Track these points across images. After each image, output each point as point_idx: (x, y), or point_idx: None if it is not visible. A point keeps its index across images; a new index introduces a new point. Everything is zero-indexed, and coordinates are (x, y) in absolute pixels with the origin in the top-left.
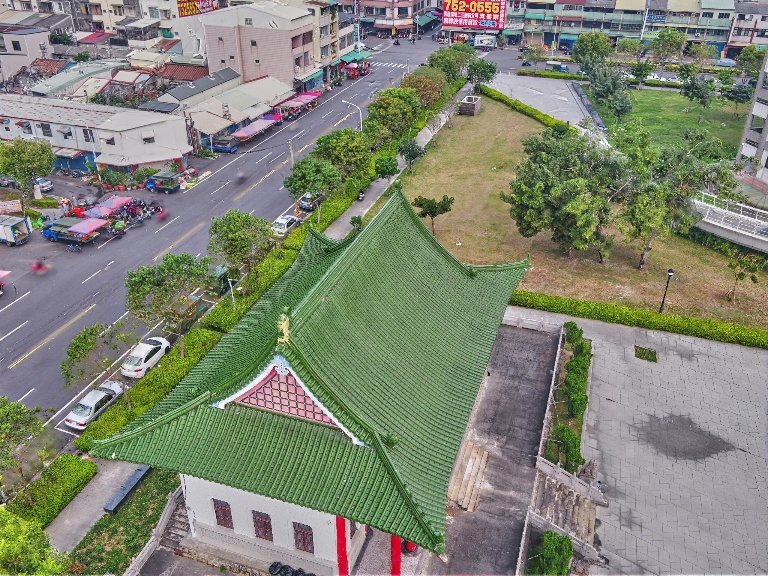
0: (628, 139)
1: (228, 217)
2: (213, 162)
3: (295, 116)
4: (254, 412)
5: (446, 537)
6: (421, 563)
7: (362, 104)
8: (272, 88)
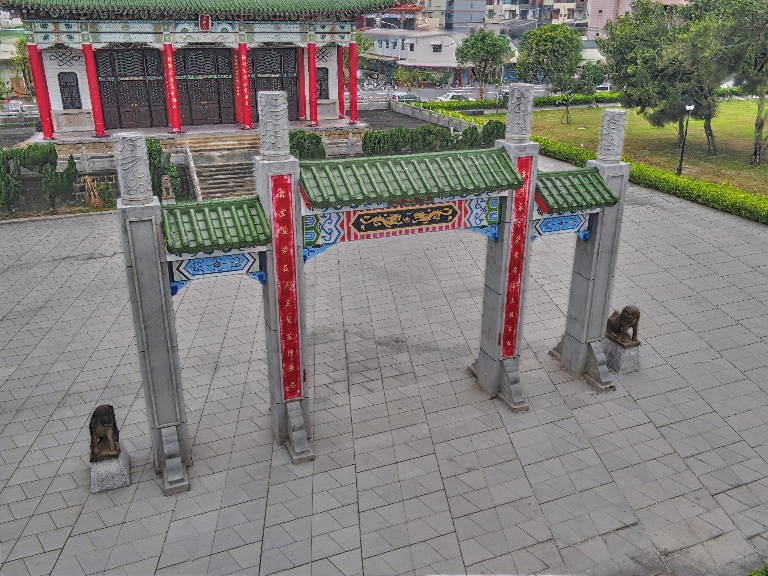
0: None
1: None
2: None
3: None
4: None
5: None
6: (87, 139)
7: None
8: None
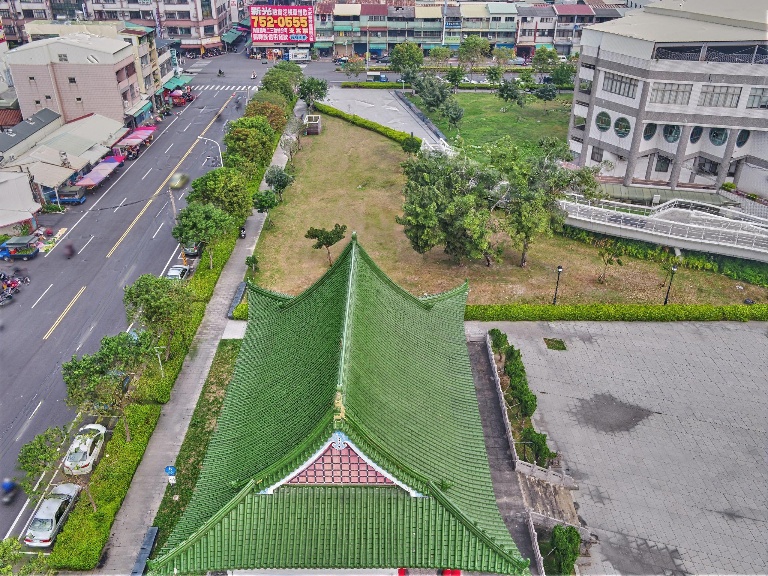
0: (502, 155)
1: (142, 283)
2: (64, 217)
3: (135, 154)
4: (304, 489)
5: None
6: None
7: (218, 138)
8: (102, 127)
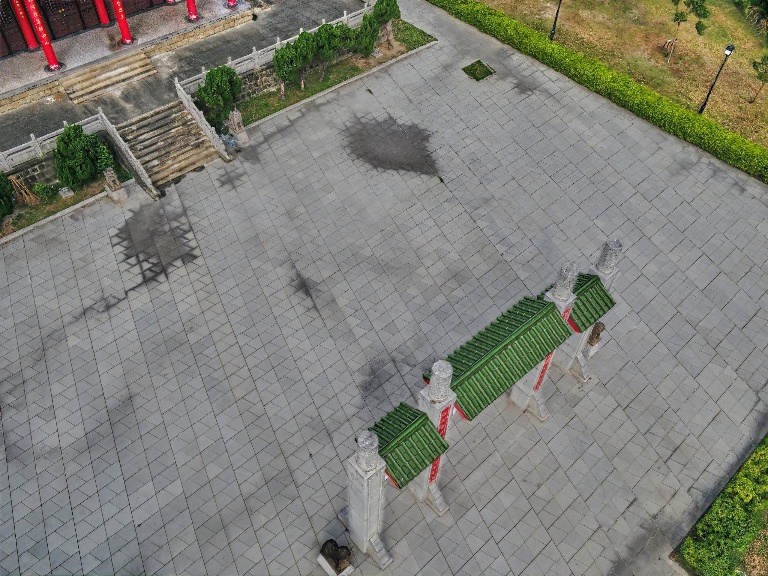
0: None
1: None
2: None
3: None
4: None
5: (28, 110)
6: None
7: None
8: None
